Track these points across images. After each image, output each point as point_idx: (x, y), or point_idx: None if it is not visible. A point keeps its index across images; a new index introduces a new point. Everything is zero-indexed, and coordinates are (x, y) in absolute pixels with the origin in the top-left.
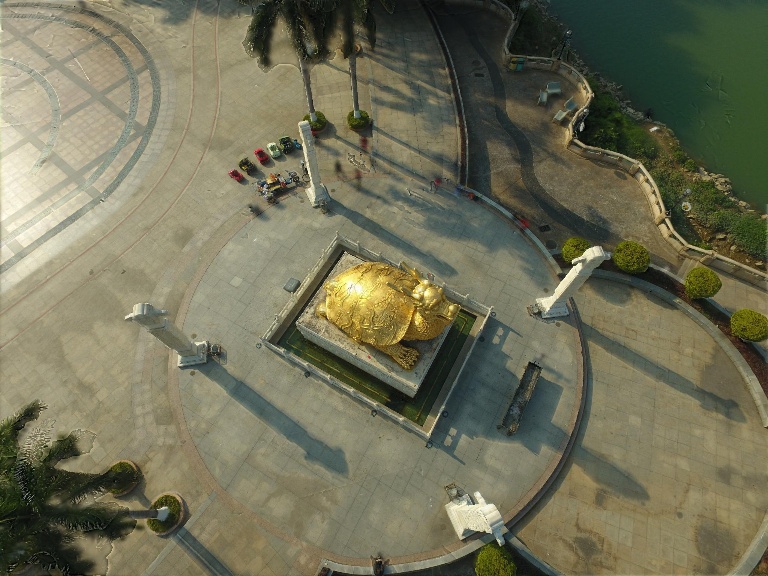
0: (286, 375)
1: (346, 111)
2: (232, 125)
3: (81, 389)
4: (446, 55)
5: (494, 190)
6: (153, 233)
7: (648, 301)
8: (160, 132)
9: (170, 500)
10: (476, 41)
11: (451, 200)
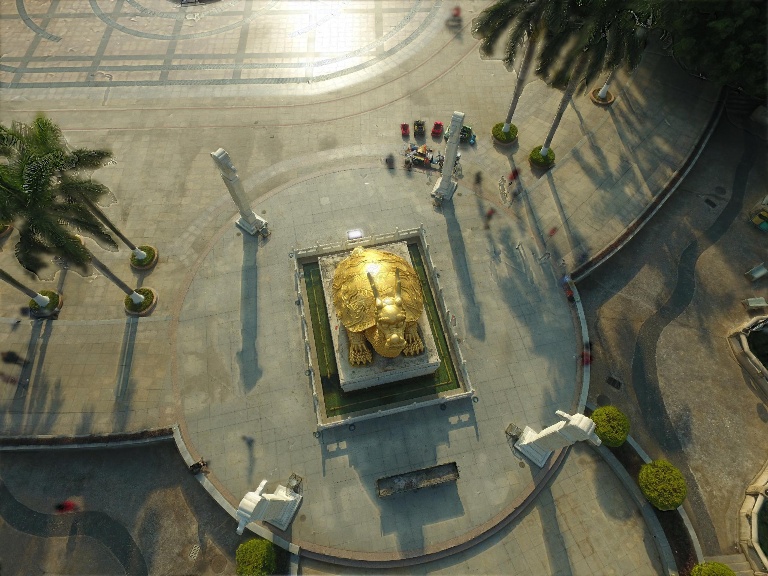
0: (285, 290)
1: (541, 143)
2: (442, 91)
3: (180, 187)
4: (689, 160)
5: (603, 309)
6: (314, 127)
7: (642, 542)
8: (390, 62)
9: (149, 295)
10: (745, 171)
11: (547, 281)
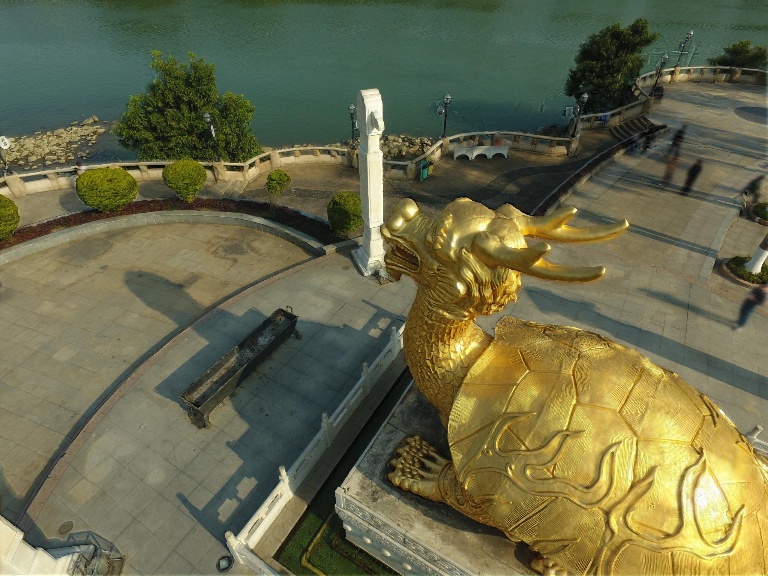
0: None
1: None
2: None
3: None
4: None
5: None
6: None
7: None
8: None
9: (757, 277)
10: None
11: None
